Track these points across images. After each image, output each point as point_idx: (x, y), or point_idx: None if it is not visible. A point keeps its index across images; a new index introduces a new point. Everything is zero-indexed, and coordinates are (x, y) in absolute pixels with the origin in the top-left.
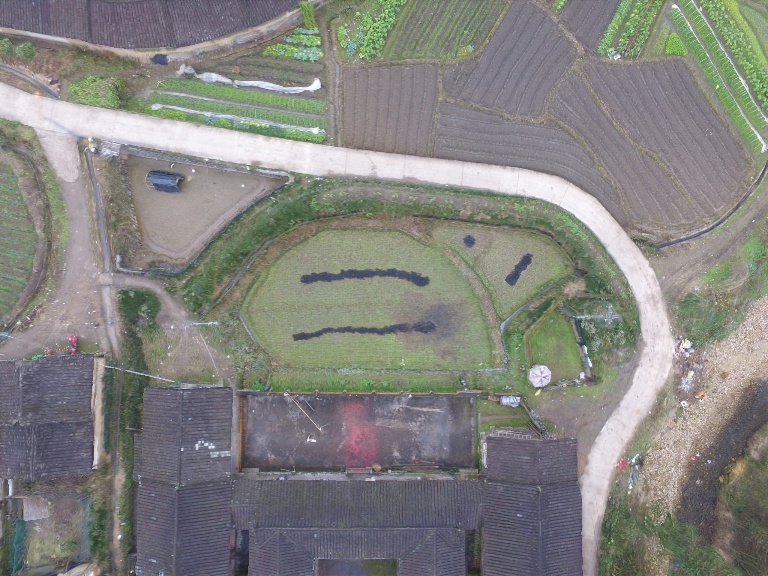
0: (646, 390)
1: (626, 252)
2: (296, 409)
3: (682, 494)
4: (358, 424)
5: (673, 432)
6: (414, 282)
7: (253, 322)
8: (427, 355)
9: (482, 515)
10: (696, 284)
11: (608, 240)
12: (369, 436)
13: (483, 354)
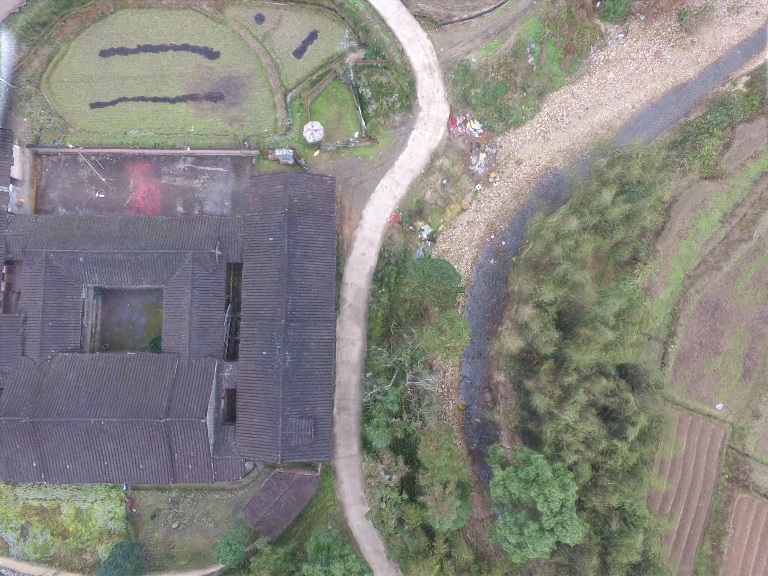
0: (420, 151)
1: (405, 25)
2: (87, 168)
3: (476, 273)
4: (145, 181)
5: (467, 213)
6: (206, 56)
7: (53, 92)
8: (216, 122)
9: (243, 246)
10: (474, 56)
11: (388, 14)
12: (155, 192)
13: (269, 121)
